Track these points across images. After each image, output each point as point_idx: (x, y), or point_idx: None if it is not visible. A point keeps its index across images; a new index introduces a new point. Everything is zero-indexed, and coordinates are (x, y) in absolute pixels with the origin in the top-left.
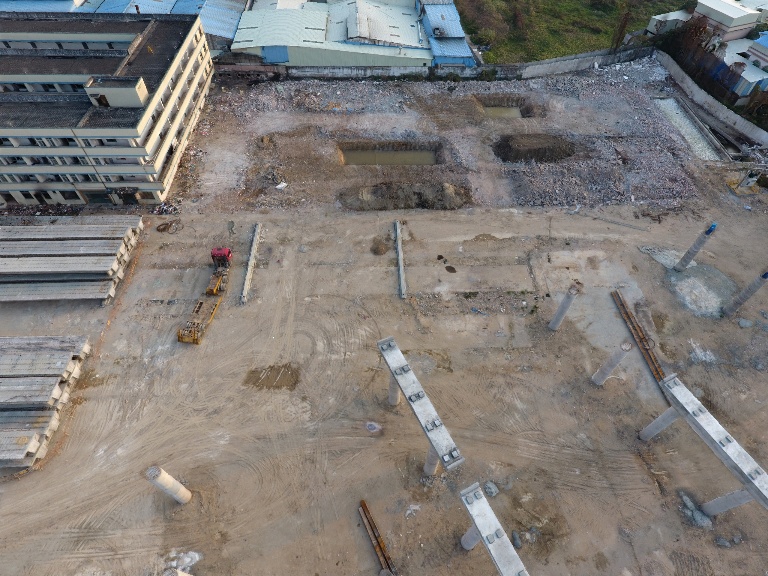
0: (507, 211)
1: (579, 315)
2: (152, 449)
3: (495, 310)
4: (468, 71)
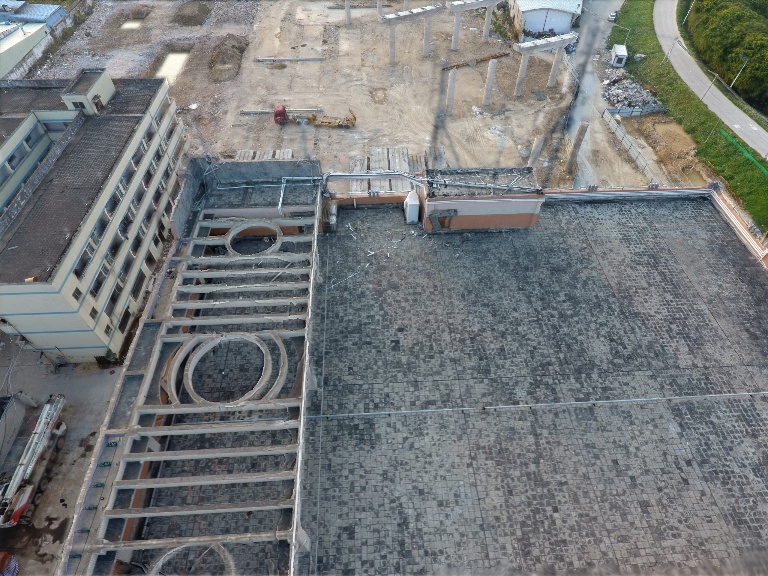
0: (256, 27)
1: (342, 17)
2: (425, 128)
3: (336, 36)
4: (68, 21)
